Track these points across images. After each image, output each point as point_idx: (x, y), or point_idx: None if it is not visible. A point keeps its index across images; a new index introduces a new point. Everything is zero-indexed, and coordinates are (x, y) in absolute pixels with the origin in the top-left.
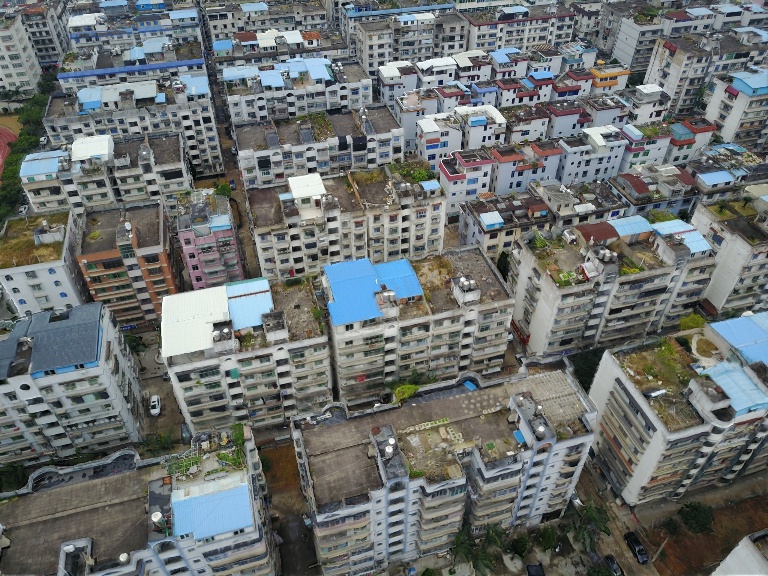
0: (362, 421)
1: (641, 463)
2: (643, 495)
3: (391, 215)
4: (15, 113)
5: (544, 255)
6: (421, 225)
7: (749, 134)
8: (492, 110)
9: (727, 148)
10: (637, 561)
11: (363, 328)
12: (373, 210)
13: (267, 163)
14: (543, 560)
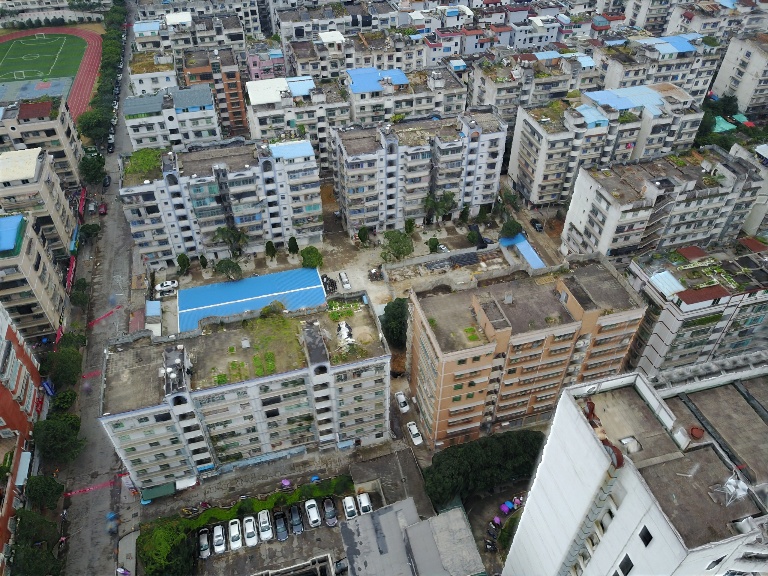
0: (372, 130)
1: (537, 167)
2: (540, 192)
3: (389, 55)
4: (97, 21)
5: (488, 71)
6: (409, 65)
7: (654, 28)
8: (464, 7)
9: (628, 26)
10: (536, 230)
11: (371, 98)
12: (377, 51)
13: (301, 32)
14: (480, 230)
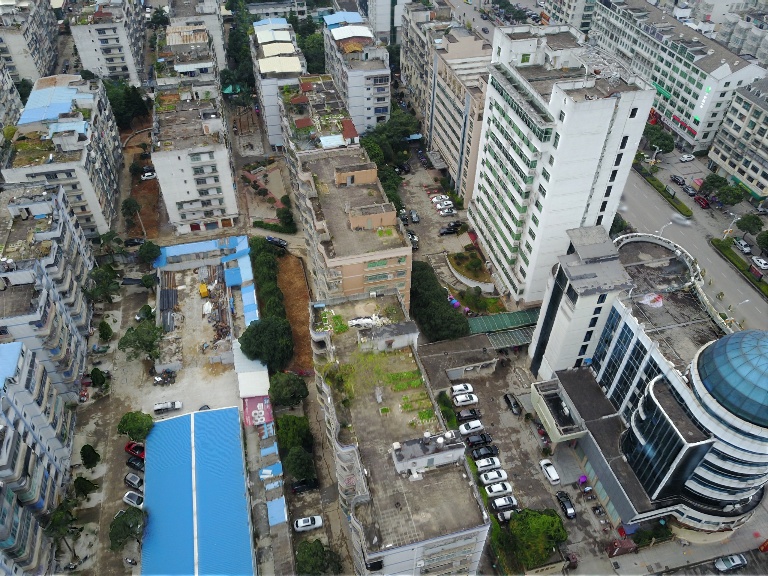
0: None
1: (88, 200)
2: (106, 218)
3: None
4: None
5: None
6: None
7: None
8: None
9: None
10: None
11: None
12: None
13: None
14: None
